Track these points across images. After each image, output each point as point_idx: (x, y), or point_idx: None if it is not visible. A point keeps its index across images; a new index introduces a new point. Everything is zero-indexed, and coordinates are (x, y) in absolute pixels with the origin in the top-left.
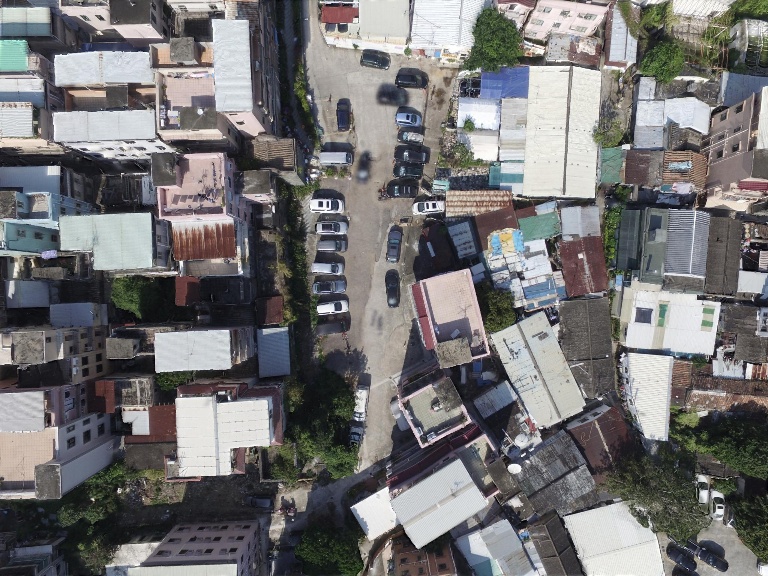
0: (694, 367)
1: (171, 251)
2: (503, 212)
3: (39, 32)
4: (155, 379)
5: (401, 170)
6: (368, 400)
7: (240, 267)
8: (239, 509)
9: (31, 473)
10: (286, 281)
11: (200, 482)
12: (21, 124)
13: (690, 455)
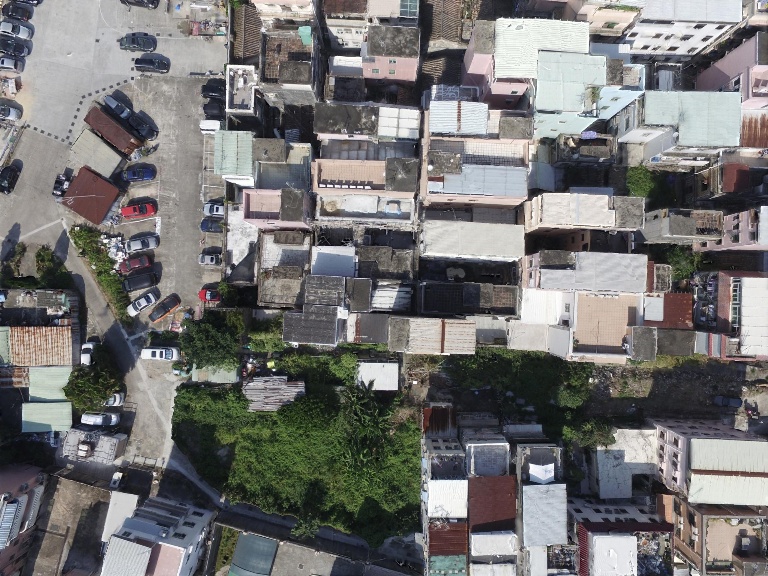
0: None
1: None
2: None
3: None
4: None
5: None
6: None
7: None
8: (703, 408)
9: (605, 338)
10: None
11: (666, 379)
12: None
13: None
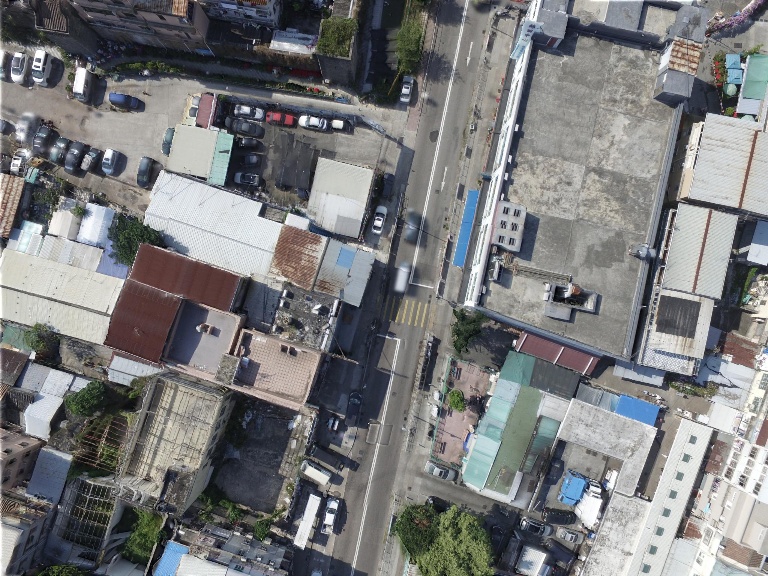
0: None
1: None
2: None
3: None
4: None
5: (62, 144)
6: None
7: None
8: None
9: None
10: None
11: None
12: None
13: None
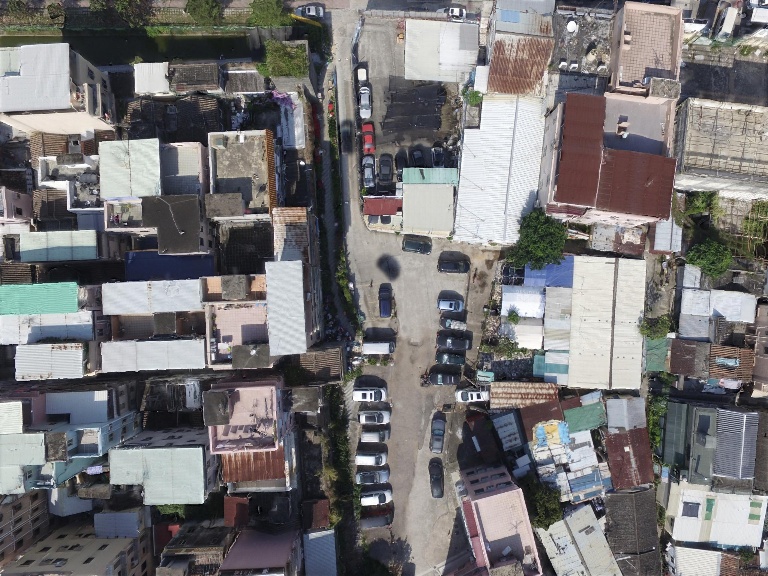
0: (741, 560)
1: (219, 471)
2: (548, 403)
3: (85, 255)
4: None
5: (444, 358)
6: None
7: (288, 482)
8: None
9: None
10: (331, 481)
11: None
12: (71, 366)
13: None
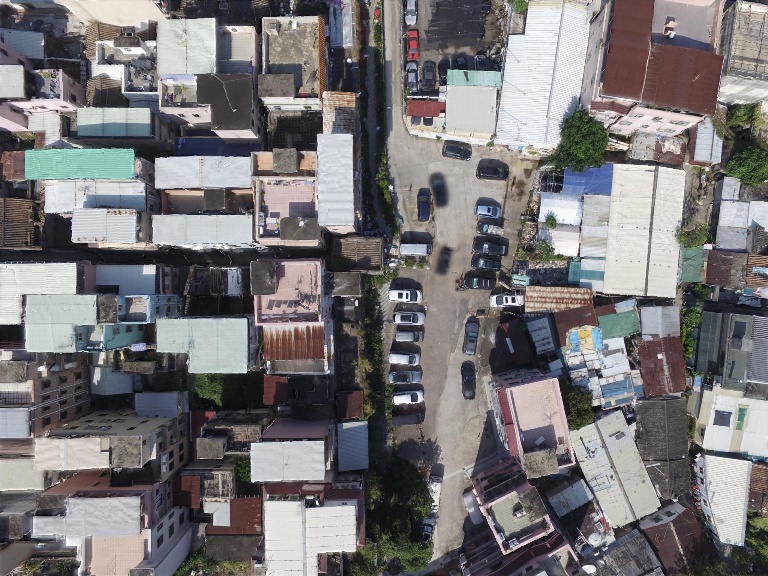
0: None
1: (260, 350)
2: (583, 309)
3: (139, 132)
4: (236, 470)
5: (480, 262)
6: (441, 490)
7: (326, 366)
8: None
9: (122, 572)
10: (366, 374)
11: None
12: (125, 231)
13: (765, 560)
